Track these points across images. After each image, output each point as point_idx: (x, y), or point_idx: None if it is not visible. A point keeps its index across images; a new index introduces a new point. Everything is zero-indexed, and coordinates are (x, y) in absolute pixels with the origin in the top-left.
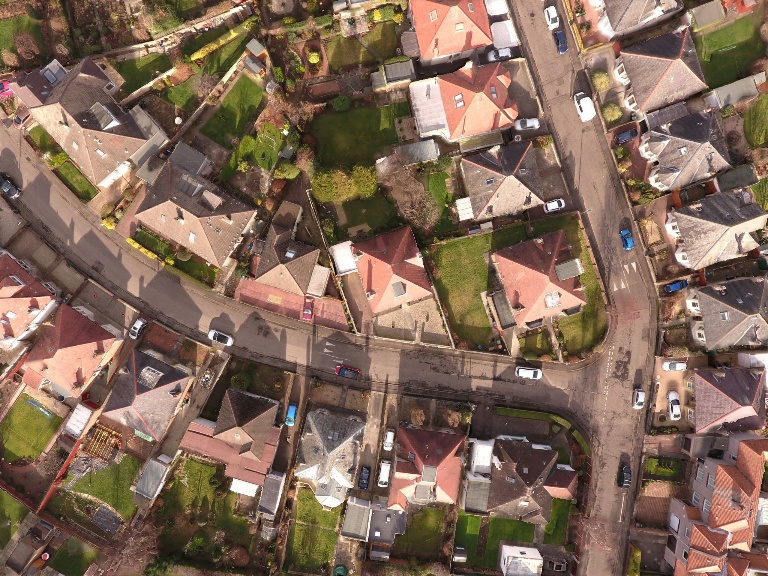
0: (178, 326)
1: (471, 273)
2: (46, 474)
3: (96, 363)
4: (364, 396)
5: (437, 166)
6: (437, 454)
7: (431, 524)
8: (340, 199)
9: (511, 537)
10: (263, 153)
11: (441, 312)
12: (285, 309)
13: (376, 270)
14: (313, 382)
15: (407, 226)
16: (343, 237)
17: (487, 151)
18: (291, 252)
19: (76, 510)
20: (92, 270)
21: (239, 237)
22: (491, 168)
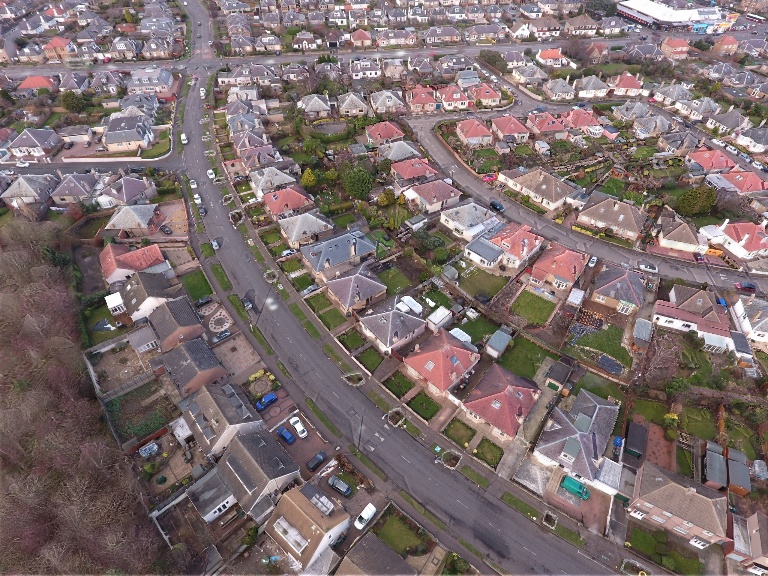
0: None
1: None
2: (554, 332)
3: (582, 267)
4: (767, 297)
5: None
6: None
7: None
8: (697, 208)
9: None
10: None
11: None
12: (683, 258)
13: (741, 229)
14: None
15: None
16: None
17: (767, 194)
18: None
19: (583, 357)
20: None
21: (643, 223)
22: None
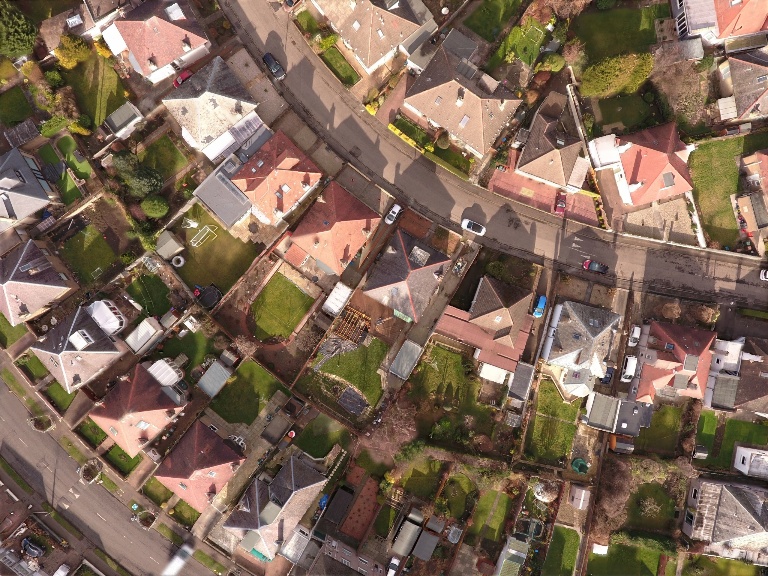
0: (431, 214)
1: (722, 175)
2: (297, 353)
3: (361, 242)
4: (612, 291)
5: (699, 66)
6: (695, 345)
7: (668, 422)
8: (609, 91)
9: (746, 439)
10: (525, 47)
11: (693, 211)
12: (537, 202)
13: (646, 160)
14: (562, 275)
15: (673, 121)
16: (598, 134)
17: (758, 50)
18: (561, 140)
19: (323, 390)
20: (350, 155)
21: None
22: (765, 65)
